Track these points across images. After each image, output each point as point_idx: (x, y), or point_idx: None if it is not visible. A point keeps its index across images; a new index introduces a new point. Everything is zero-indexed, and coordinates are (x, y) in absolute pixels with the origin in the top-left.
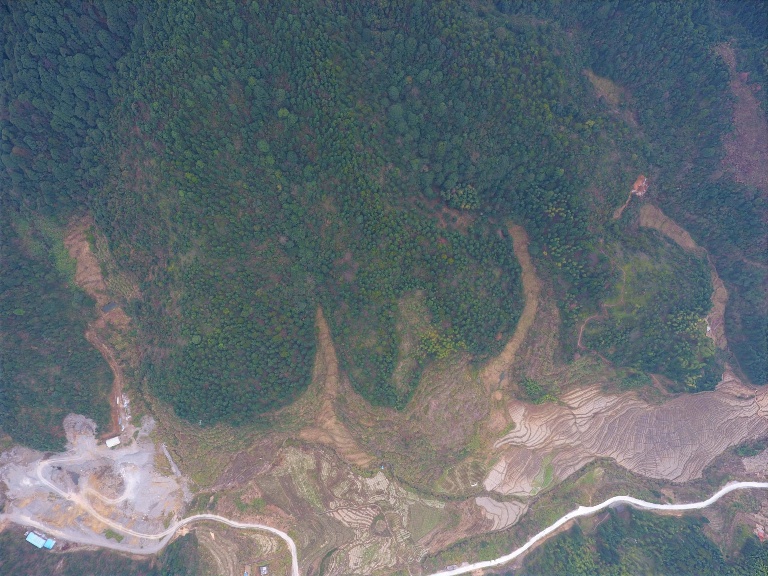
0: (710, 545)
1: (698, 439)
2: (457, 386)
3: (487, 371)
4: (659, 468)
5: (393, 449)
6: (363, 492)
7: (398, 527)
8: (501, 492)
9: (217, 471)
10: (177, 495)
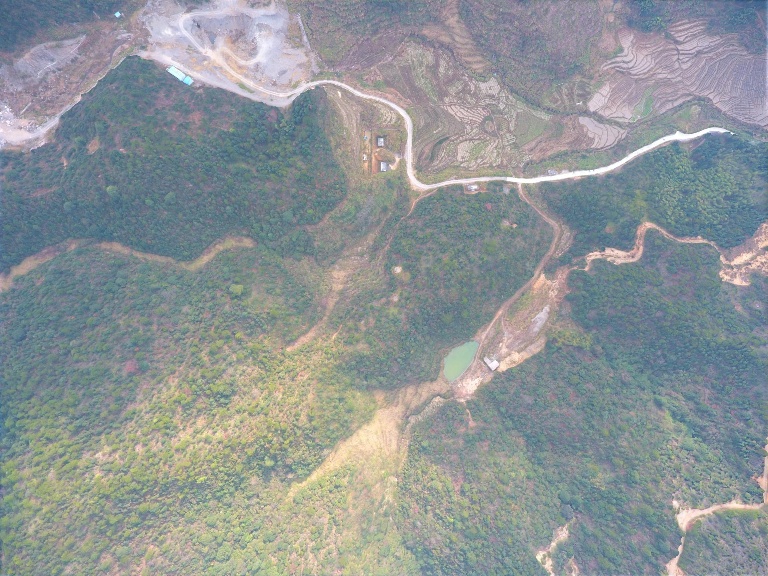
0: None
1: None
2: None
3: None
4: (752, 113)
5: (509, 52)
6: (475, 94)
7: (505, 131)
8: (603, 115)
9: (344, 49)
10: (305, 67)
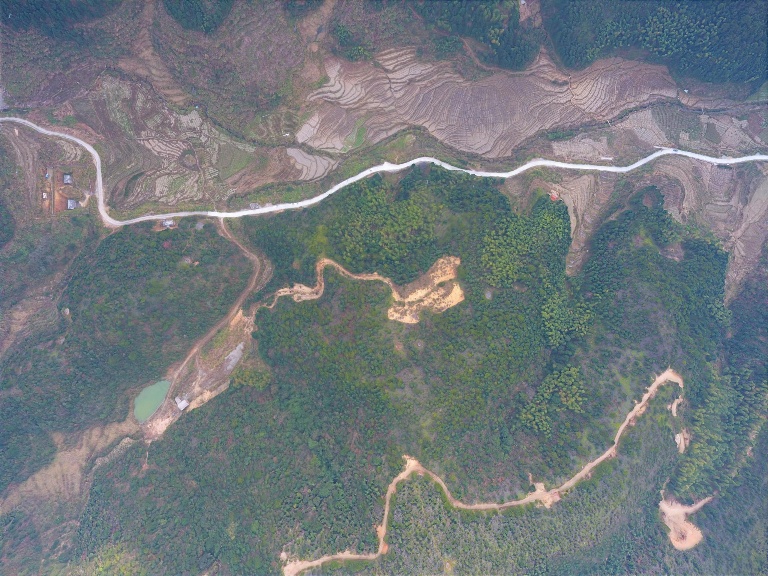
0: (500, 194)
1: (510, 119)
2: (271, 26)
3: (305, 22)
4: (469, 141)
5: (206, 84)
6: (176, 127)
7: (207, 165)
8: (312, 146)
9: (32, 85)
10: None
